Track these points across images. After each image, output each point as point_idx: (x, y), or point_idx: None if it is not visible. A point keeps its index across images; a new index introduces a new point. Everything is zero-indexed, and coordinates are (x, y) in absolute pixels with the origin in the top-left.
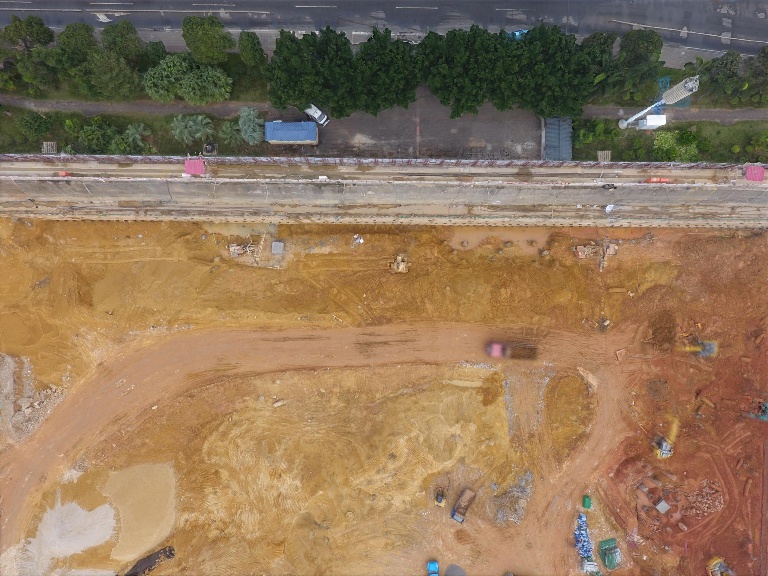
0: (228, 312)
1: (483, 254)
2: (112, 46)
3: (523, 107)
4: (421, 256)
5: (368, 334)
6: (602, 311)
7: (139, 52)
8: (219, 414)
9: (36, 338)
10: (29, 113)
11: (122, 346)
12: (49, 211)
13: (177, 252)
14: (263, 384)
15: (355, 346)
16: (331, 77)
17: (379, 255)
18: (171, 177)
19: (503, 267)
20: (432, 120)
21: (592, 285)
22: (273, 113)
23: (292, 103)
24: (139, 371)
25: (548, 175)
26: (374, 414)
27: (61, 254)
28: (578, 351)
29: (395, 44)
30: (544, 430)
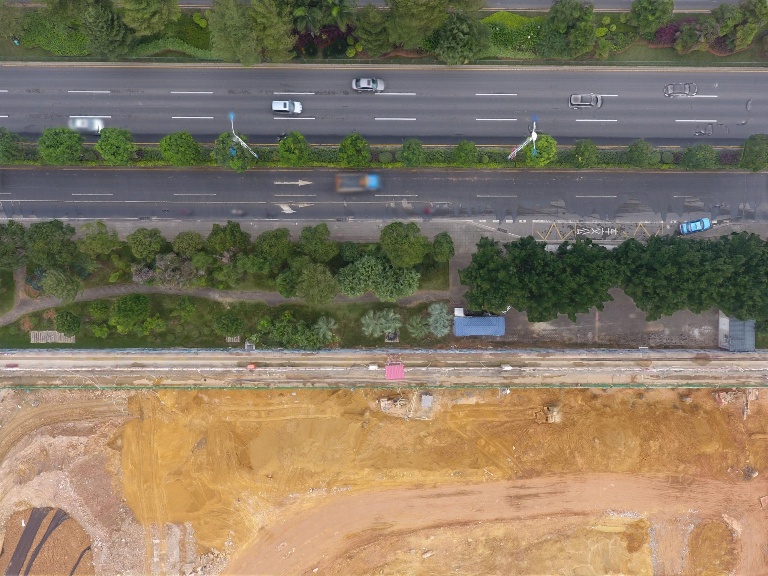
0: (384, 471)
1: (624, 399)
2: (312, 253)
3: (714, 306)
4: (565, 404)
5: (518, 487)
6: (747, 459)
7: (334, 254)
8: (371, 568)
9: (199, 504)
10: (225, 315)
11: (282, 509)
12: (217, 384)
13: (330, 409)
14: (417, 540)
15: (506, 499)
16: (536, 290)
17: (525, 405)
18: (354, 365)
19: (647, 415)
20: (611, 306)
21: (735, 432)
22: (454, 301)
23: (494, 312)
24: (299, 534)
25: (725, 359)
26: (519, 561)
27: (215, 413)
28: (723, 498)
29: (599, 256)
30: (688, 575)
